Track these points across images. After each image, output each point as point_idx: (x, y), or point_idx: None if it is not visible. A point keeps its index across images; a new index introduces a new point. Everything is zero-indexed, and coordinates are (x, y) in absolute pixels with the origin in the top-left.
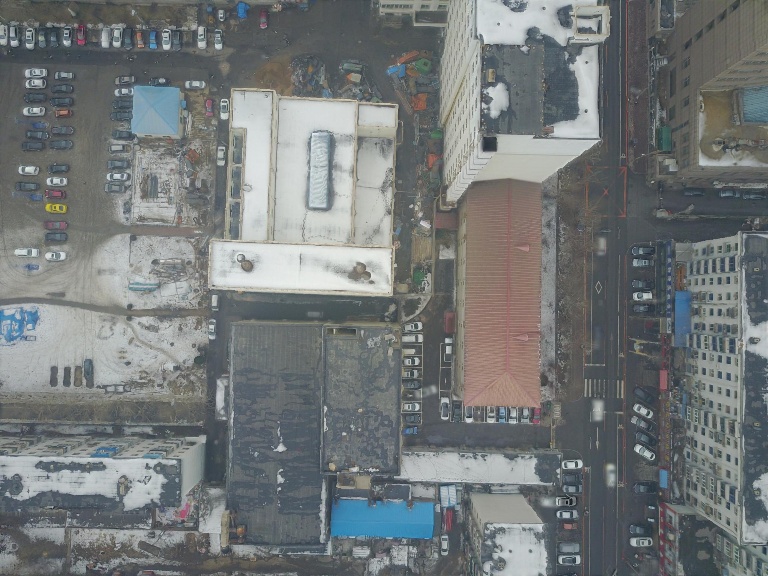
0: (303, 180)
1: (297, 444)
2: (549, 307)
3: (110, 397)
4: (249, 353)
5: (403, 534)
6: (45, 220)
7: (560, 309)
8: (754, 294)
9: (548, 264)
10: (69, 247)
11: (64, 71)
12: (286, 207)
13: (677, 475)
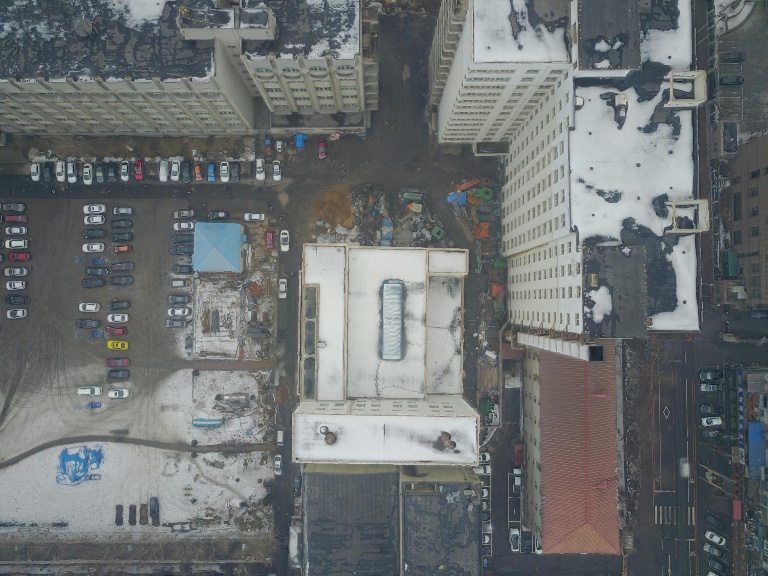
0: (375, 330)
1: None
2: None
3: (176, 535)
4: (323, 502)
5: None
6: (107, 357)
7: (628, 436)
8: None
9: None
10: (131, 384)
11: (122, 206)
12: (359, 358)
13: None
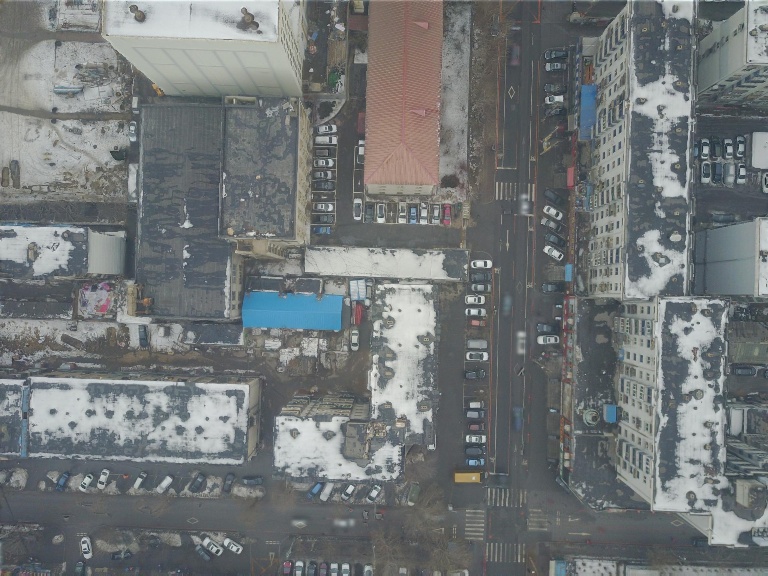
0: None
1: (203, 221)
2: (462, 111)
3: (35, 196)
4: (158, 134)
5: (313, 326)
6: None
7: (473, 113)
8: (642, 55)
9: (462, 69)
10: None
11: None
12: None
13: (582, 269)
